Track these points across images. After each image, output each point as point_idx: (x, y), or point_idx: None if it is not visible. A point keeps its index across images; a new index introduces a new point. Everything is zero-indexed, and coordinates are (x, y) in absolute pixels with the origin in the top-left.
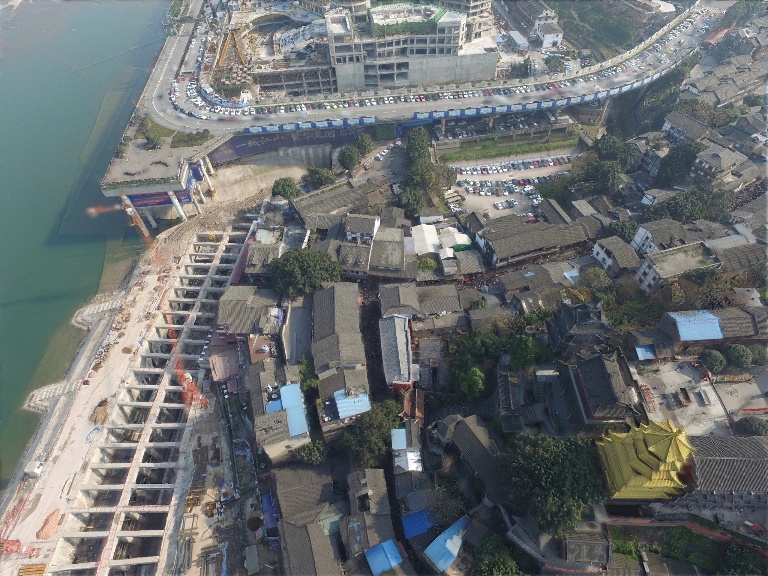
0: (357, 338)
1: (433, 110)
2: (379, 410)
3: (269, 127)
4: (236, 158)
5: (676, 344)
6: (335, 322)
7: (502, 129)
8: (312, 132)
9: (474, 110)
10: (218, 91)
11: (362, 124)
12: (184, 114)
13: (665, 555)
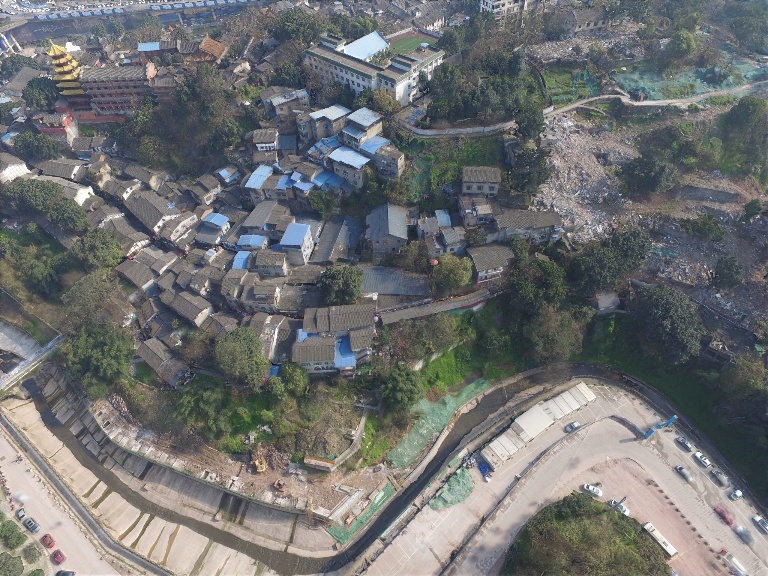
0: (25, 85)
1: (163, 4)
2: (14, 103)
3: (51, 15)
4: (36, 40)
5: (141, 55)
6: (15, 78)
7: (221, 20)
8: (86, 22)
9: (191, 4)
10: (35, 3)
11: (115, 14)
12: (2, 13)
13: (111, 137)
